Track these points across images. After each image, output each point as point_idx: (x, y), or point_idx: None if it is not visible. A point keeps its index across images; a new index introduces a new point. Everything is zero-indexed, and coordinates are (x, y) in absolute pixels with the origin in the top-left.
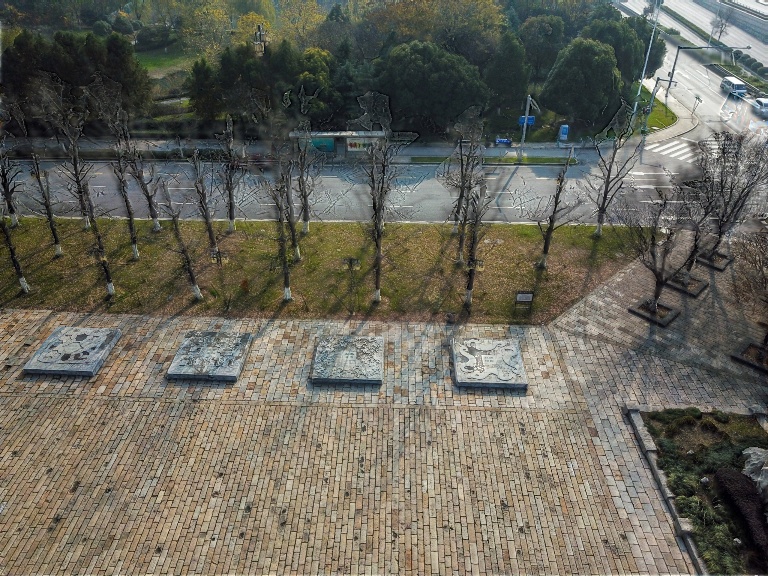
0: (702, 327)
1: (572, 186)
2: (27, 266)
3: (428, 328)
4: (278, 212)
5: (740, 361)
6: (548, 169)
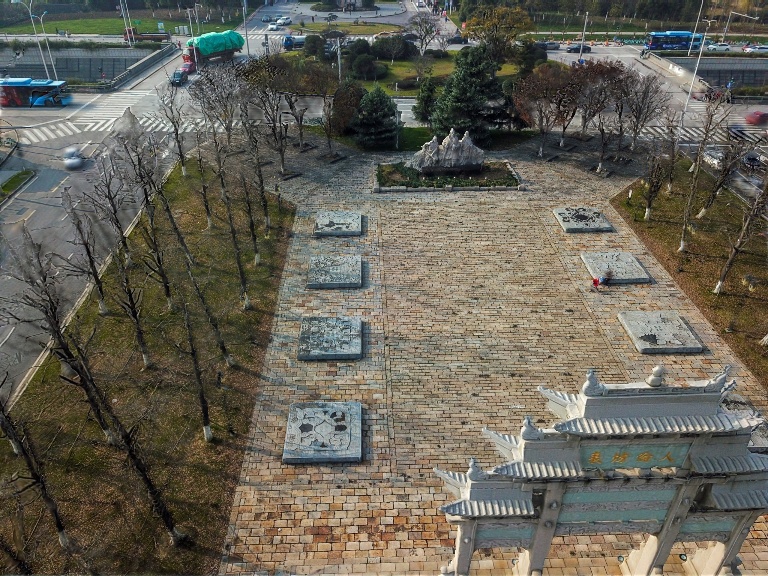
0: (303, 165)
1: (83, 179)
2: (96, 574)
3: (296, 244)
4: (25, 344)
5: (335, 162)
6: (34, 186)
